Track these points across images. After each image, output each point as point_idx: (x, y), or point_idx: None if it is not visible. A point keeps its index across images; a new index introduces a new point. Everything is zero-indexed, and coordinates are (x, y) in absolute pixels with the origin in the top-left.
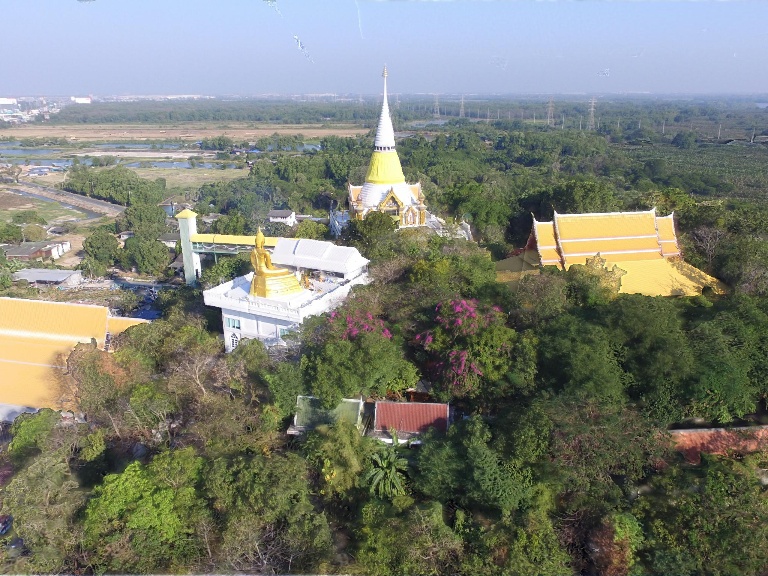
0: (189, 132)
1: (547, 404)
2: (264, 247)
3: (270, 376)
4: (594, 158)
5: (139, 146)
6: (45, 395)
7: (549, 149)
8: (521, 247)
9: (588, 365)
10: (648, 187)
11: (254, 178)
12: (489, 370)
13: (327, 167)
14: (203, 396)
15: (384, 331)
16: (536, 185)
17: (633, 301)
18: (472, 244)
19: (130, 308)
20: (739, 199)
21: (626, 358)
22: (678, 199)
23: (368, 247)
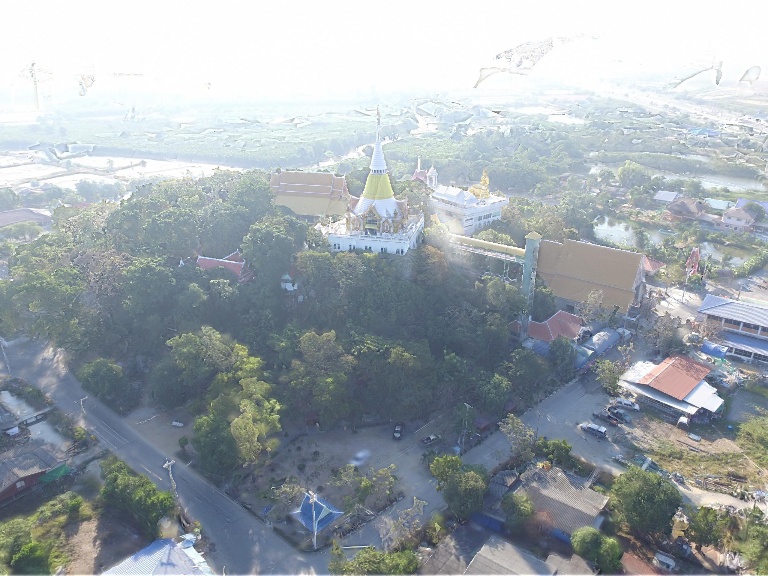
0: None
1: None
2: None
3: None
4: None
5: None
6: None
7: None
8: None
9: None
10: None
11: None
12: None
13: None
14: None
15: None
16: None
17: None
18: None
19: None
20: None
21: None
22: None
23: None
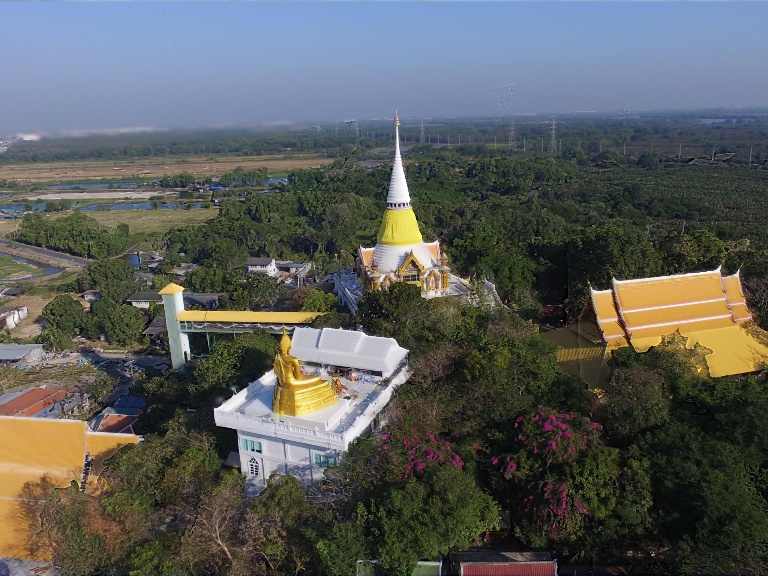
0: (146, 168)
1: (702, 571)
2: (265, 324)
3: (324, 544)
4: (570, 184)
5: (95, 186)
6: (9, 538)
7: (522, 176)
8: (548, 304)
9: (728, 500)
10: (632, 214)
11: (224, 220)
12: (594, 506)
13: (300, 204)
14: (231, 569)
15: (454, 458)
16: (526, 219)
17: (765, 409)
18: (515, 316)
19: (104, 393)
20: (725, 223)
21: (767, 483)
22: (712, 243)
23: (395, 325)
